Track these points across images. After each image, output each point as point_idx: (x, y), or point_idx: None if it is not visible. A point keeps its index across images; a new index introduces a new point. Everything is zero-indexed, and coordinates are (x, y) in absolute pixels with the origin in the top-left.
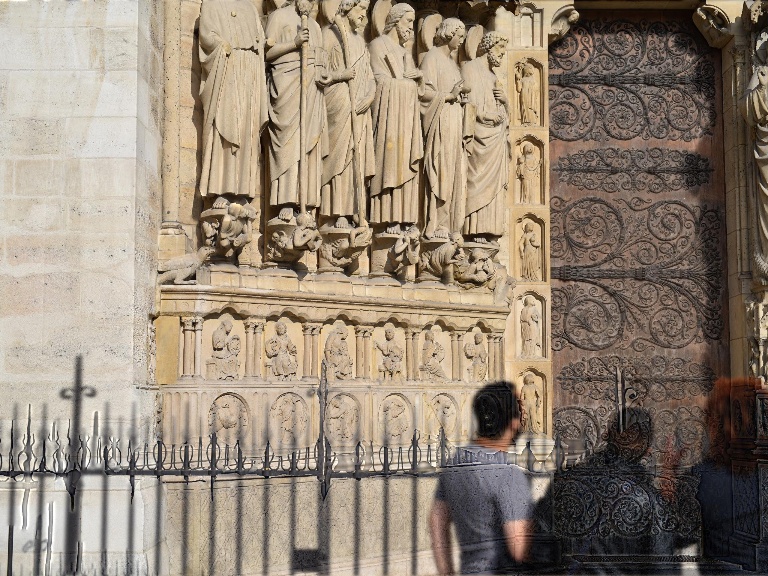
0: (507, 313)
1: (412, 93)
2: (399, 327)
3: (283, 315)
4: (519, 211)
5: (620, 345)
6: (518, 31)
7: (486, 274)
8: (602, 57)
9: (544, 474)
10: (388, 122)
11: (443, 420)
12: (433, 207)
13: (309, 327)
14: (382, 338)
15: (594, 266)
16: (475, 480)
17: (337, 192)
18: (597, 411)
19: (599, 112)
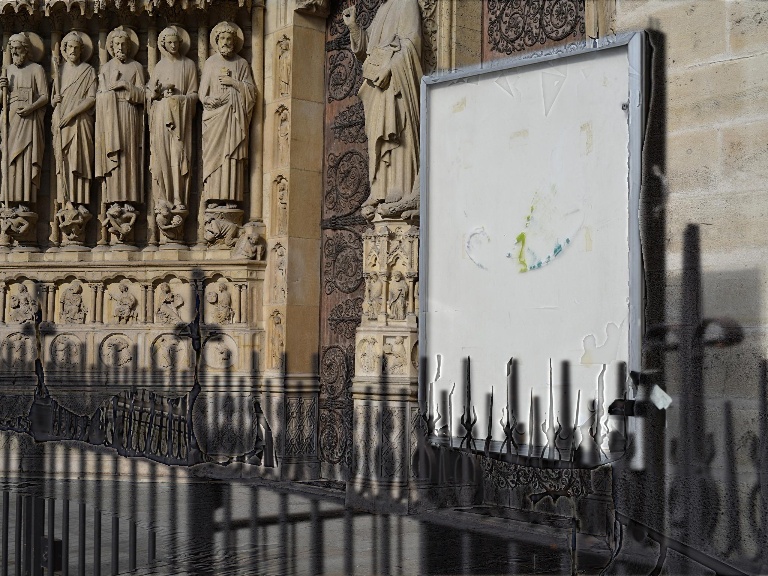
0: (246, 265)
1: (108, 102)
2: (136, 282)
3: (27, 279)
4: (275, 174)
5: (363, 287)
6: (283, 13)
7: (212, 234)
8: (362, 14)
9: (280, 403)
10: (95, 127)
11: (172, 354)
12: (154, 185)
13: (43, 286)
14: (119, 291)
15: (350, 214)
16: (203, 404)
17: (58, 187)
18: (348, 349)
19: (358, 68)
